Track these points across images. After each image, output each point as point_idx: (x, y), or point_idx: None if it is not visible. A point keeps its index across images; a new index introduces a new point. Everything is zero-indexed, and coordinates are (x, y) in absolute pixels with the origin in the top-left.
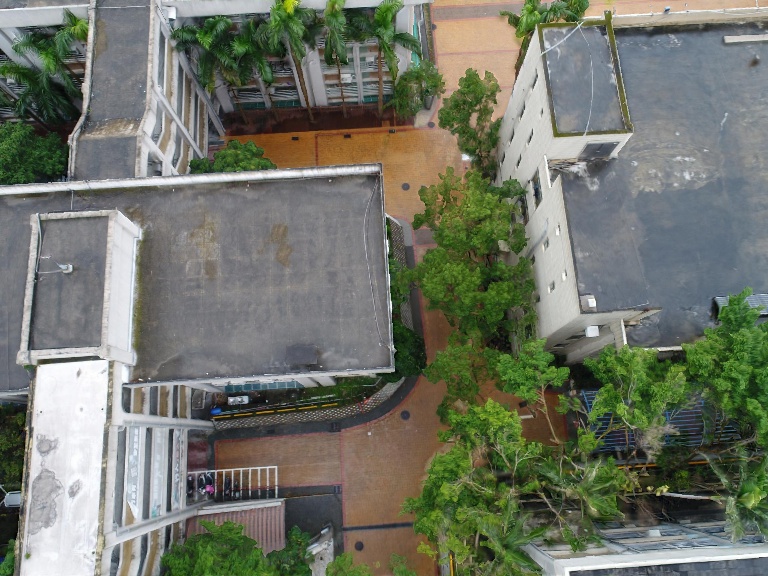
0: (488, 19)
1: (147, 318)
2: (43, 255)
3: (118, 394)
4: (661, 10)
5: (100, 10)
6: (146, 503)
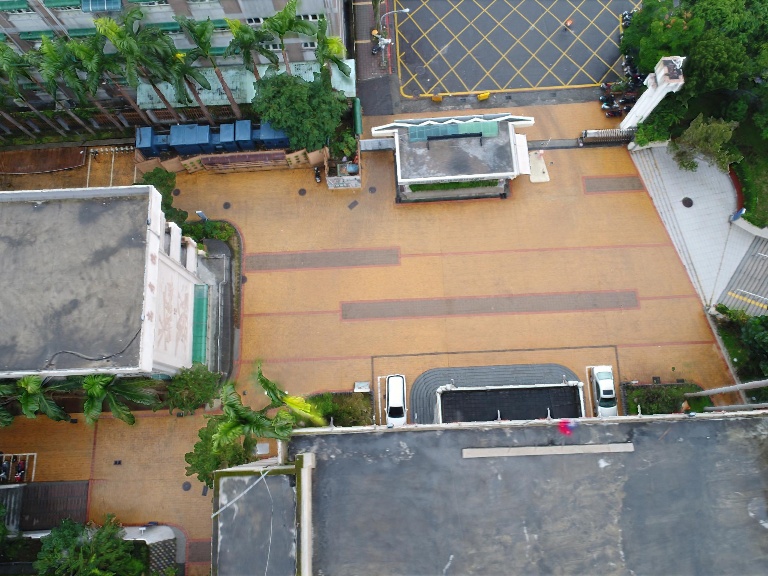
0: (305, 271)
1: None
2: None
3: None
4: (497, 264)
5: None
6: None
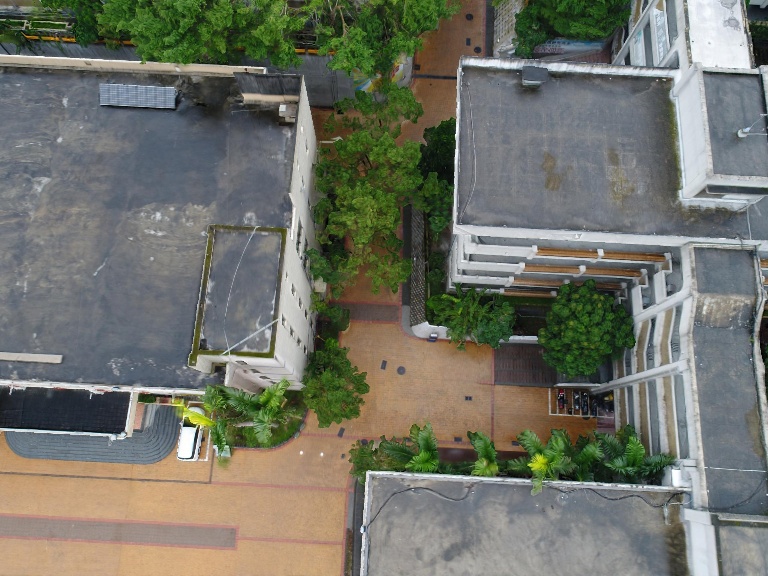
0: None
1: (665, 125)
2: (766, 149)
3: (682, 55)
4: None
5: (763, 470)
6: (646, 40)
